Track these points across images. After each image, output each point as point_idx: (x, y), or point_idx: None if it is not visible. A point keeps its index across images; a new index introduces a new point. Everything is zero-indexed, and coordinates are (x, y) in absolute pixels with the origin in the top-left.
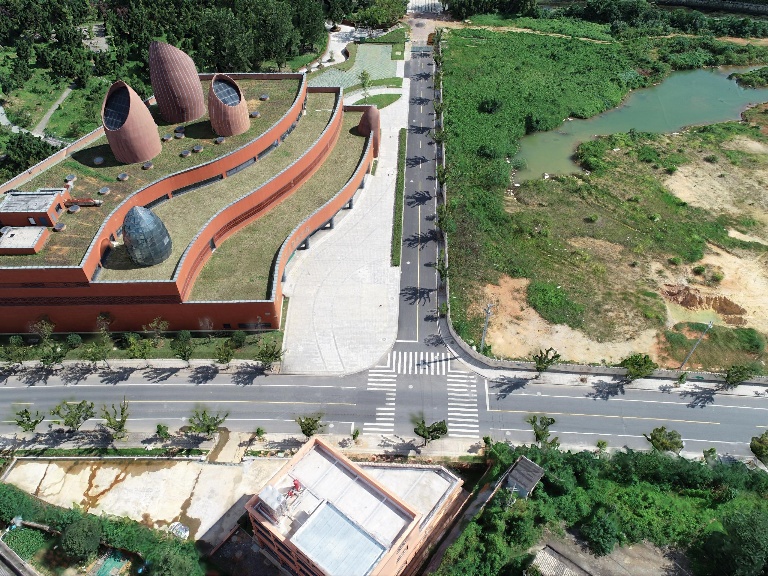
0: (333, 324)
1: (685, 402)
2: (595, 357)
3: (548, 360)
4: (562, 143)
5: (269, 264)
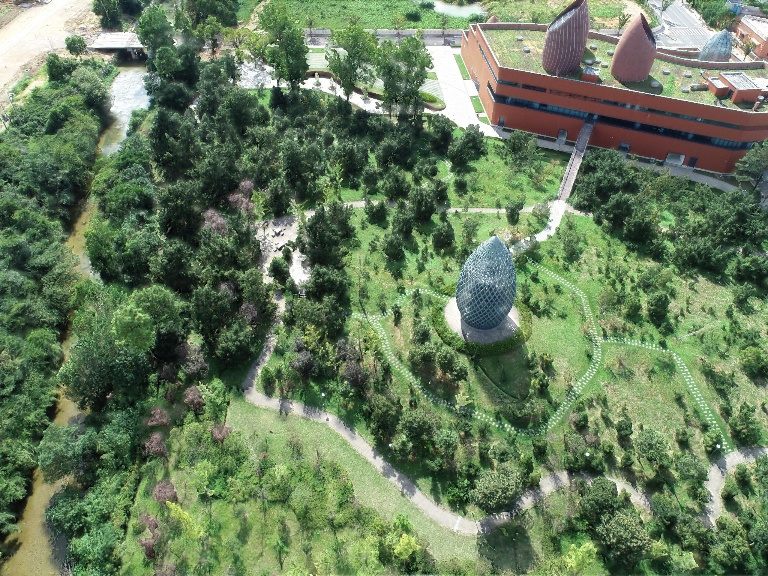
0: None
1: None
2: (637, 7)
3: (665, 2)
4: (442, 7)
5: None
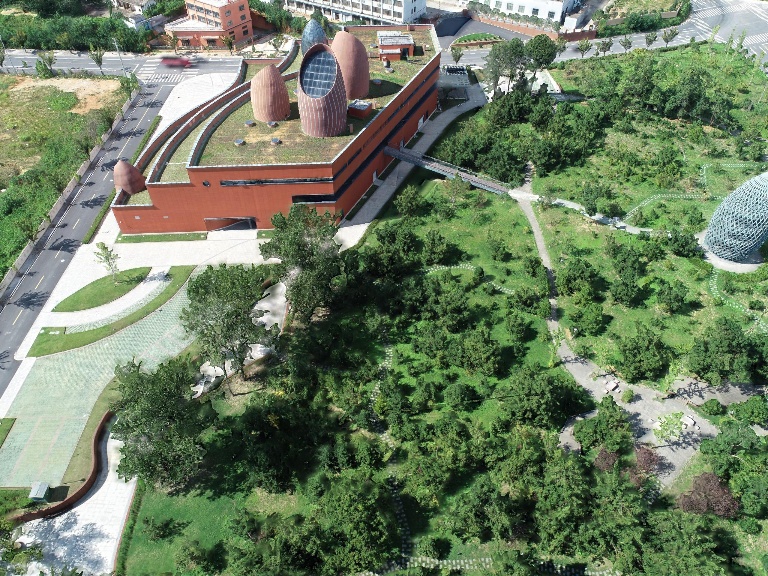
0: (212, 90)
1: (32, 67)
2: None
3: None
4: None
5: (246, 81)
